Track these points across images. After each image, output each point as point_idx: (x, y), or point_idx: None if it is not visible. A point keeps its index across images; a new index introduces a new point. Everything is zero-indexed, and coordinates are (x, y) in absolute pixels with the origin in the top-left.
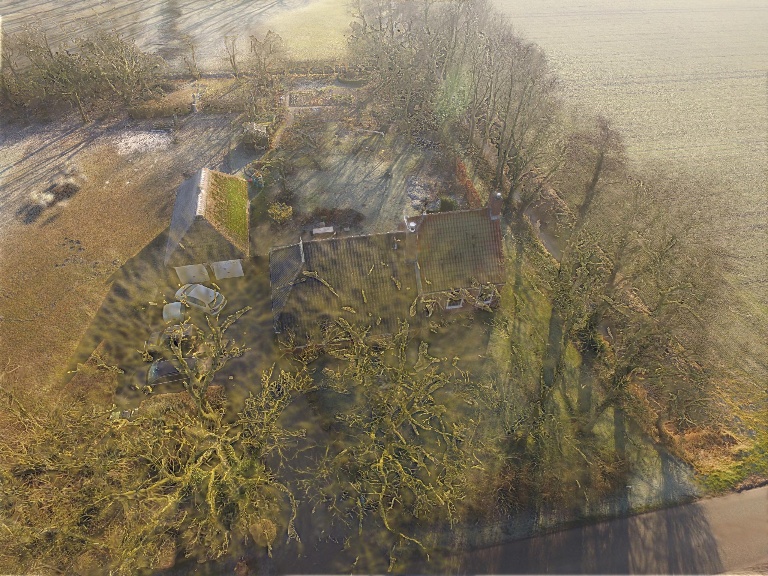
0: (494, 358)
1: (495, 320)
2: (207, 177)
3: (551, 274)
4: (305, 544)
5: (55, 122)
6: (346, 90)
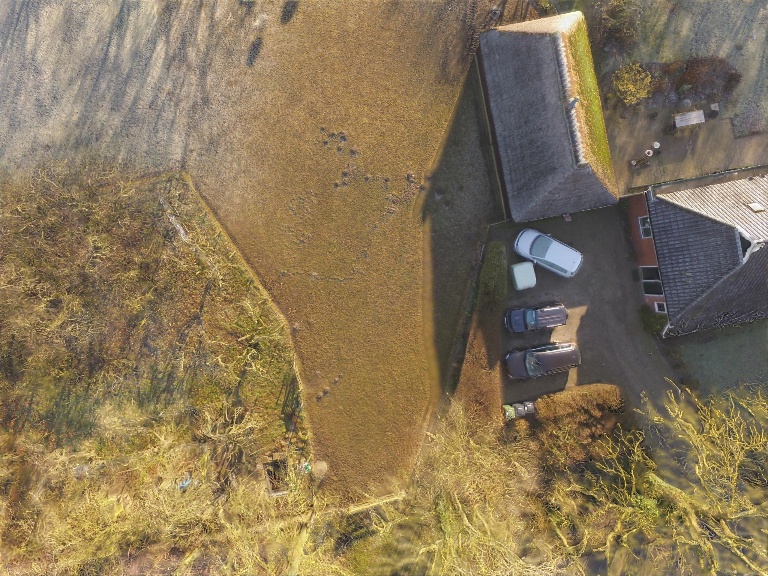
0: None
1: None
2: (568, 57)
3: None
4: None
5: None
6: None
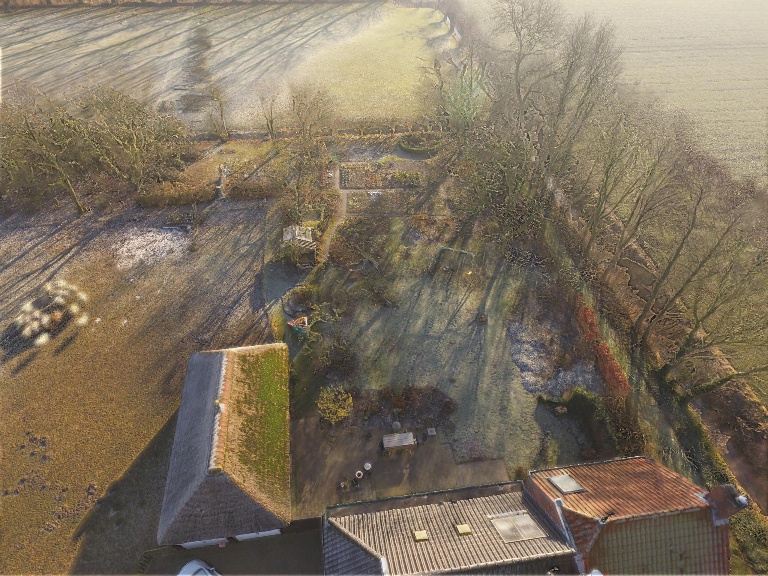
0: None
1: None
2: (230, 370)
3: (761, 545)
4: None
5: (44, 211)
6: (411, 163)
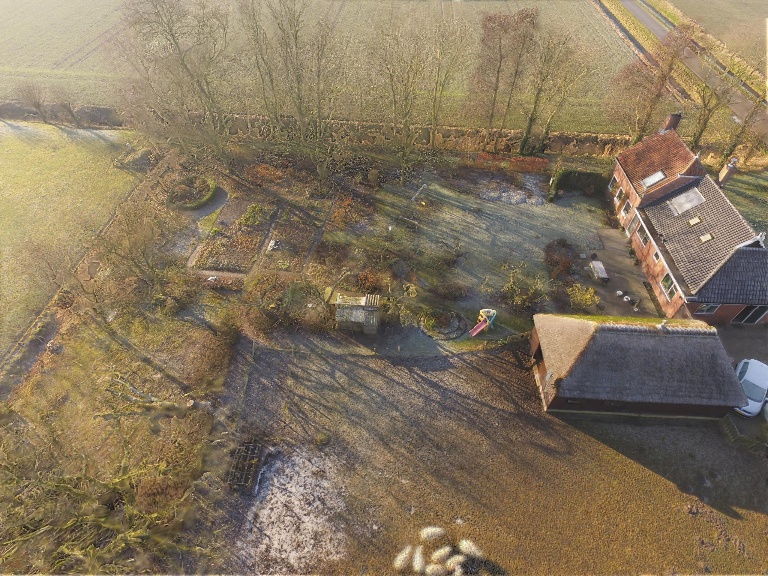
0: None
1: None
2: None
3: None
4: None
5: None
6: (229, 208)
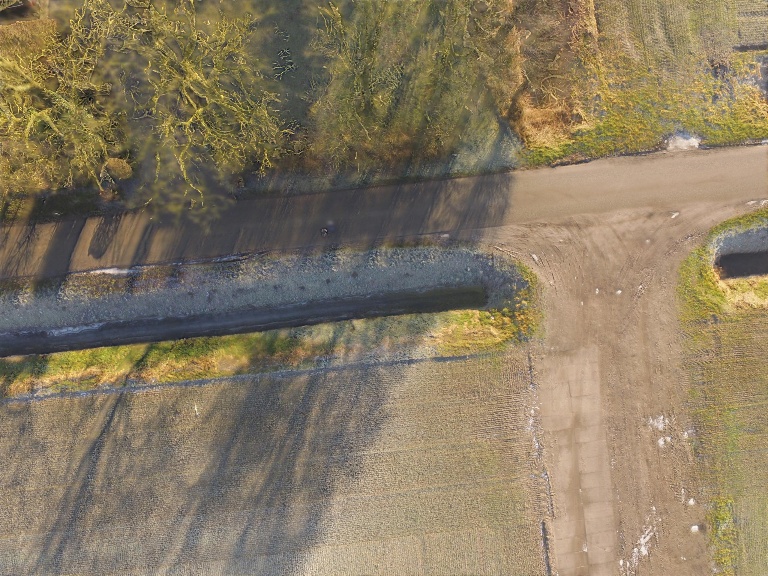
0: (366, 4)
1: None
2: None
3: None
4: (162, 179)
5: None
6: None
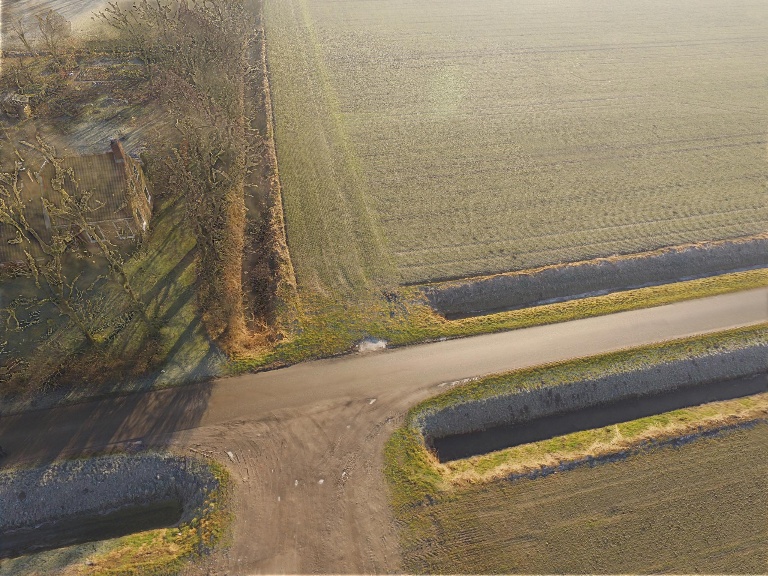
0: None
1: (137, 252)
2: None
3: None
4: None
5: None
6: (138, 66)
